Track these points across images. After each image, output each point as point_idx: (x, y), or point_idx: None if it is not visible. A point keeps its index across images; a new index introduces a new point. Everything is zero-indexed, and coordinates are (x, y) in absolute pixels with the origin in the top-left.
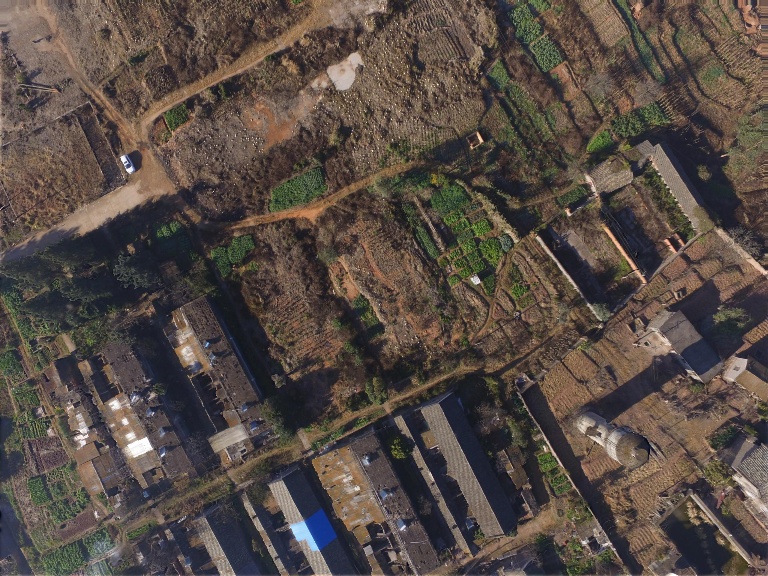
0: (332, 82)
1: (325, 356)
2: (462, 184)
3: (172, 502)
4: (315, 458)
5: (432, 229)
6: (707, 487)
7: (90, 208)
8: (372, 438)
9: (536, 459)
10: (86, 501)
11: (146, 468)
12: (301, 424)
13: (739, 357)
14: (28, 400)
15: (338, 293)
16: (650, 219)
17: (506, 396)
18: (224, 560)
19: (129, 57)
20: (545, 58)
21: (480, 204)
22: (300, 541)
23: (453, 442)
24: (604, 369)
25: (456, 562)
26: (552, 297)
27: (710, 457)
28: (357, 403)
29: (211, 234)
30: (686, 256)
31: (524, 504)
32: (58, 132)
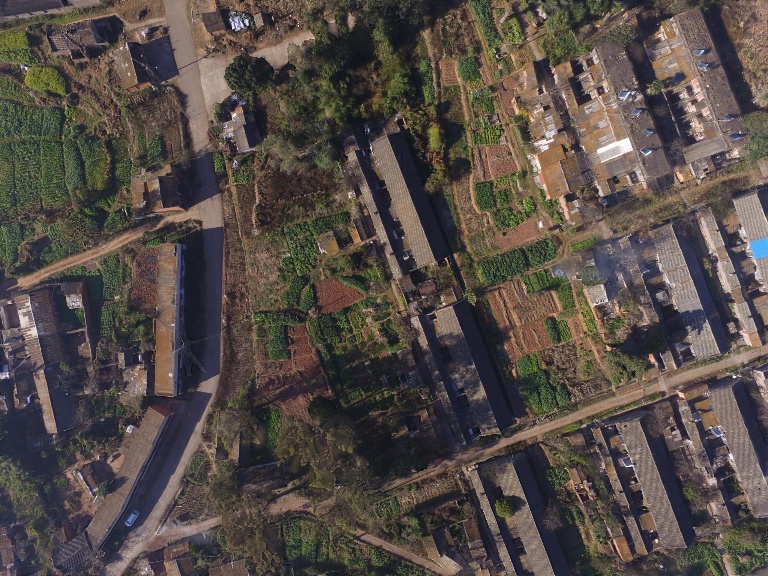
0: None
1: None
2: None
3: (621, 218)
4: None
5: None
6: None
7: None
8: None
9: None
10: (532, 210)
11: (616, 172)
12: None
13: None
14: (483, 107)
15: None
16: None
17: None
18: (683, 270)
19: None
20: None
21: None
22: (760, 259)
23: None
24: None
25: None
26: None
27: None
28: None
29: None
30: None
31: None
32: None
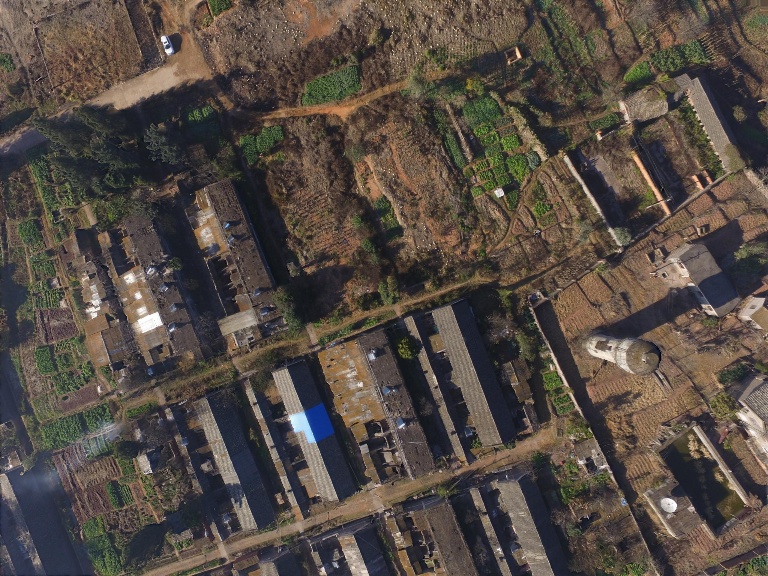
0: None
1: (342, 253)
2: (496, 97)
3: (175, 384)
4: (321, 352)
5: (461, 138)
6: (711, 422)
7: (126, 86)
8: (381, 334)
9: (541, 377)
10: (91, 375)
11: (154, 344)
12: (311, 319)
13: (757, 297)
14: (45, 270)
15: (361, 192)
16: (680, 154)
17: (518, 311)
18: (221, 443)
19: None
20: None
21: (511, 119)
22: (298, 432)
23: (461, 346)
24: (619, 295)
25: (450, 472)
26: (574, 219)
27: (717, 393)
28: (369, 302)
29: (242, 122)
30: (713, 195)
31: (525, 418)
32: (102, 9)
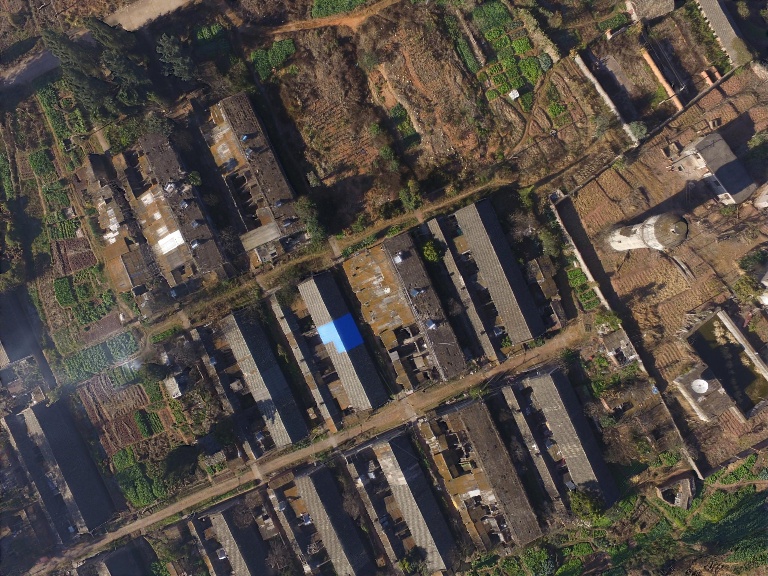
0: None
1: (360, 163)
2: (505, 1)
3: (199, 306)
4: (346, 262)
5: (473, 42)
6: (735, 308)
7: (131, 9)
8: (405, 237)
9: (566, 274)
10: (112, 303)
11: (176, 264)
12: (333, 231)
13: None
14: (58, 200)
15: (376, 102)
16: (688, 52)
17: (539, 211)
18: (249, 360)
19: None
20: None
21: (521, 23)
22: (327, 344)
23: (486, 244)
24: (637, 189)
25: (481, 375)
26: (589, 118)
27: (739, 279)
28: (390, 209)
29: (252, 37)
30: (722, 90)
31: (553, 314)
32: None
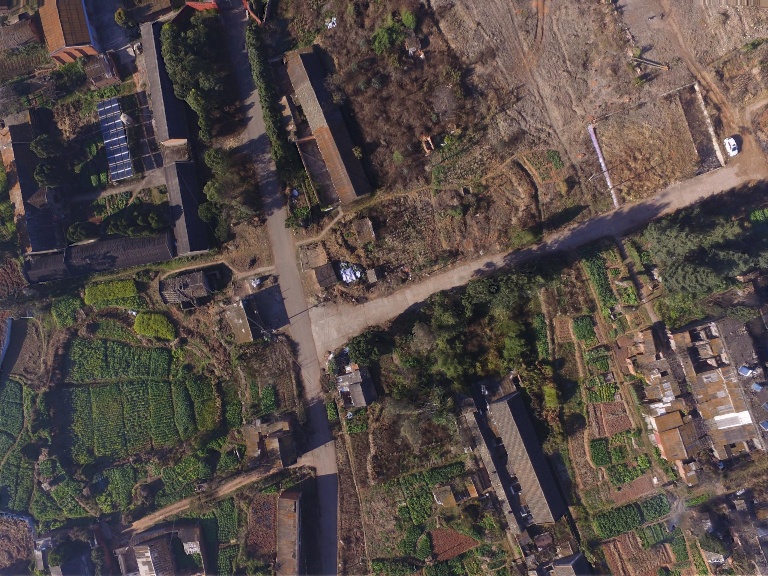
0: None
1: None
2: None
3: (734, 474)
4: None
5: None
6: None
7: (683, 185)
8: None
9: None
10: (647, 467)
11: (734, 440)
12: None
13: None
14: (598, 365)
15: None
16: None
17: None
18: None
19: (744, 43)
20: None
21: None
22: None
23: None
24: None
25: None
26: None
27: None
28: None
29: None
30: None
31: None
32: (658, 108)
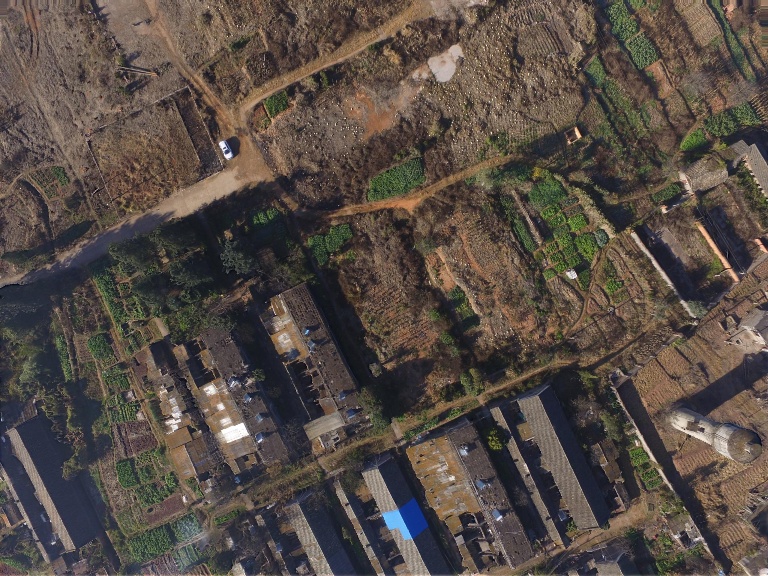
0: (433, 73)
1: (420, 346)
2: (559, 179)
3: (261, 488)
4: (409, 447)
5: (529, 223)
6: None
7: (186, 193)
8: (470, 428)
9: (627, 453)
10: (174, 485)
11: (240, 454)
12: (394, 413)
13: None
14: (118, 383)
15: (434, 284)
16: (741, 218)
17: (599, 390)
18: (316, 547)
19: (230, 43)
20: (641, 56)
21: (576, 199)
22: (392, 529)
23: (551, 434)
24: (696, 366)
25: None
26: (646, 293)
27: None
28: (452, 394)
29: (308, 222)
30: None
31: (617, 497)
32: (155, 116)
